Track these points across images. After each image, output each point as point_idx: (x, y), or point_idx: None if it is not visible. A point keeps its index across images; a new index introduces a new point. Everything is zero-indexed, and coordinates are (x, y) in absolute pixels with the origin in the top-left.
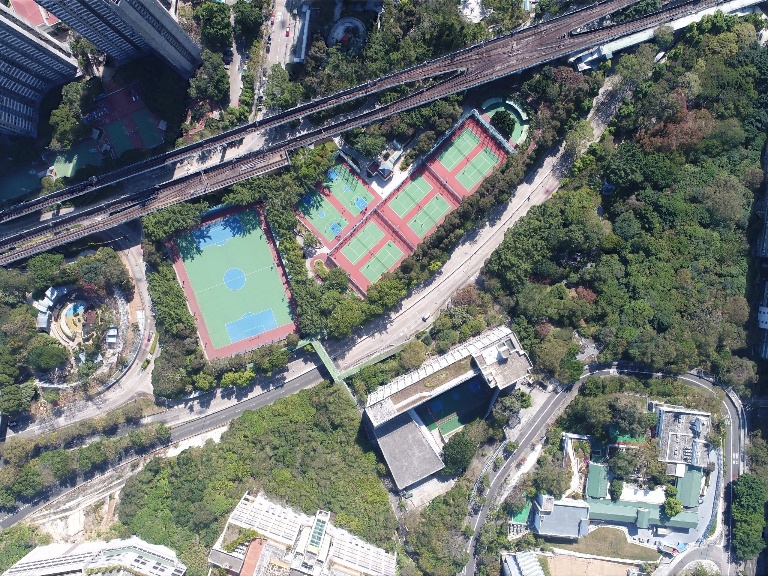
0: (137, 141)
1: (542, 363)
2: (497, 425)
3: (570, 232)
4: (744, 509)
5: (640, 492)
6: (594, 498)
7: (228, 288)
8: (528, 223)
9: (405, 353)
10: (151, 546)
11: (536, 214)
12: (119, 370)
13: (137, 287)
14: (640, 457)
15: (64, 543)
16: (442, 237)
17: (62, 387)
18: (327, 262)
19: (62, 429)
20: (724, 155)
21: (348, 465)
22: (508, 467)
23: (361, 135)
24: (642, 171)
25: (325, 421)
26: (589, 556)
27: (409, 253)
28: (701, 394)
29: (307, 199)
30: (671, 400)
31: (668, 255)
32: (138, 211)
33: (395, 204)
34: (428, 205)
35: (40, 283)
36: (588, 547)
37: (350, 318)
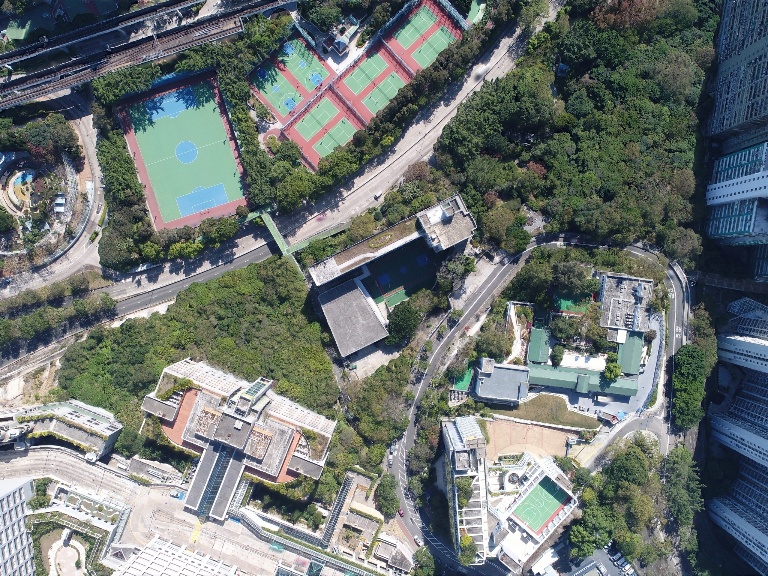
0: (92, 8)
1: (489, 231)
2: (442, 292)
3: (521, 103)
4: (684, 378)
5: (581, 358)
6: (535, 363)
7: (180, 161)
8: (481, 97)
9: (354, 224)
10: (88, 406)
11: (489, 89)
12: (66, 241)
13: (87, 158)
14: (581, 319)
15: (2, 408)
16: (395, 110)
17: (7, 254)
18: (280, 138)
19: (6, 298)
20: (677, 35)
21: (293, 335)
22: (452, 337)
23: (316, 5)
24: (595, 48)
25: (272, 294)
26: (528, 422)
27: None
28: (644, 260)
29: (262, 73)
30: (615, 268)
31: (618, 129)
32: (89, 75)
33: (350, 81)
34: (383, 83)
35: None
36: (528, 413)
37: (299, 186)
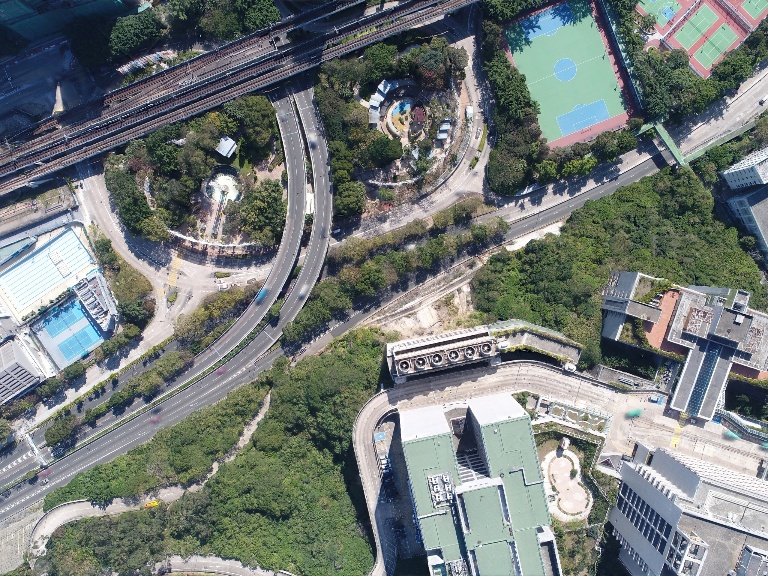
0: None
1: None
2: None
3: None
4: None
5: None
6: None
7: (559, 79)
8: None
9: (763, 126)
10: None
11: None
12: (448, 169)
13: (464, 82)
14: None
15: (418, 337)
16: None
17: (398, 184)
18: (660, 48)
19: (394, 230)
20: None
21: (708, 243)
22: None
23: None
24: None
25: (673, 205)
26: None
27: (743, 36)
28: None
29: None
30: None
31: None
32: None
33: None
34: None
35: (377, 74)
36: None
37: (708, 91)
